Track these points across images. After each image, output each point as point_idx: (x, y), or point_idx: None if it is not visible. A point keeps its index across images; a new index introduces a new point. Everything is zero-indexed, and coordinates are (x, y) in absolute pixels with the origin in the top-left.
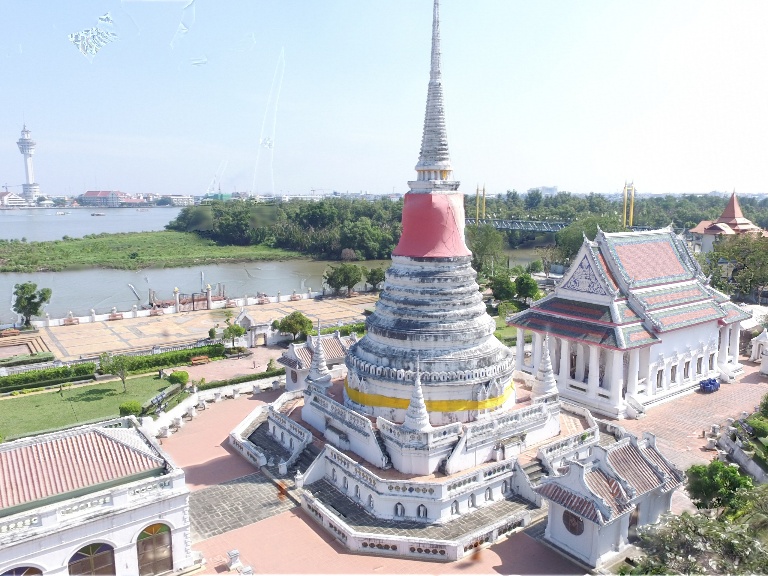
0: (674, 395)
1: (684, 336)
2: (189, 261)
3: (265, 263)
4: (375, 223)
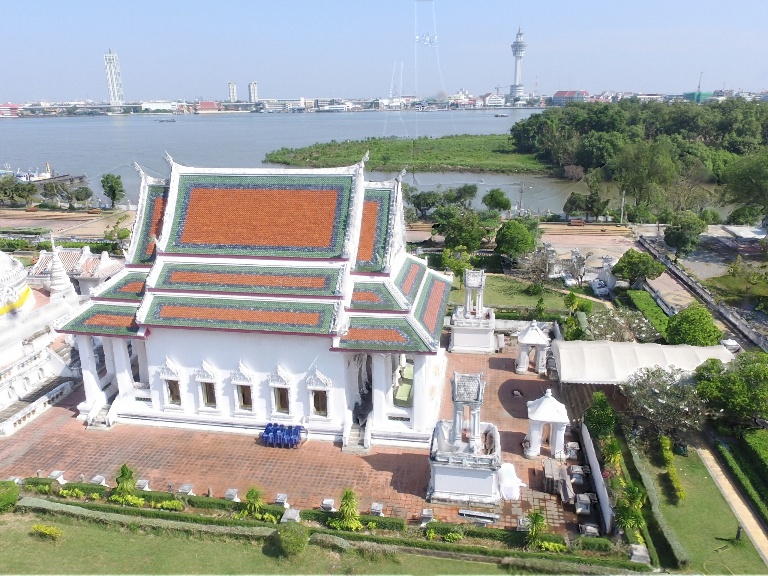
0: (209, 425)
1: (232, 344)
2: (424, 167)
3: (492, 175)
4: (684, 134)
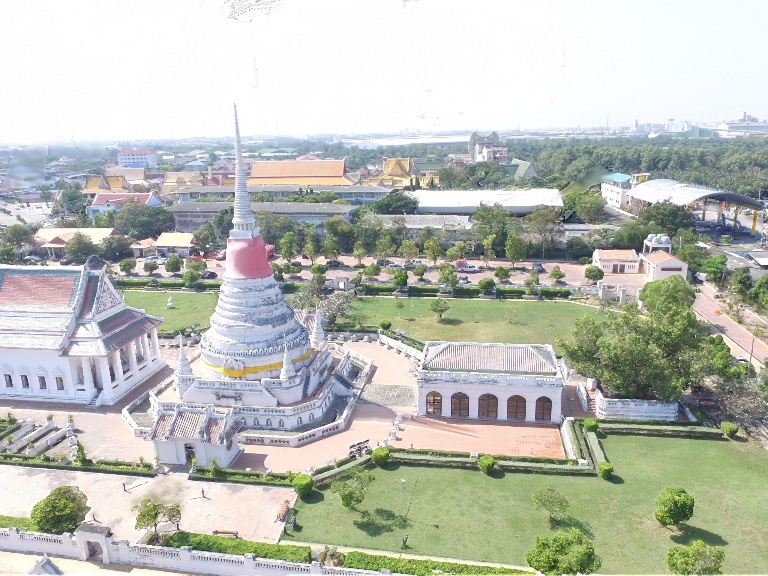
0: None
1: None
2: None
3: None
4: None
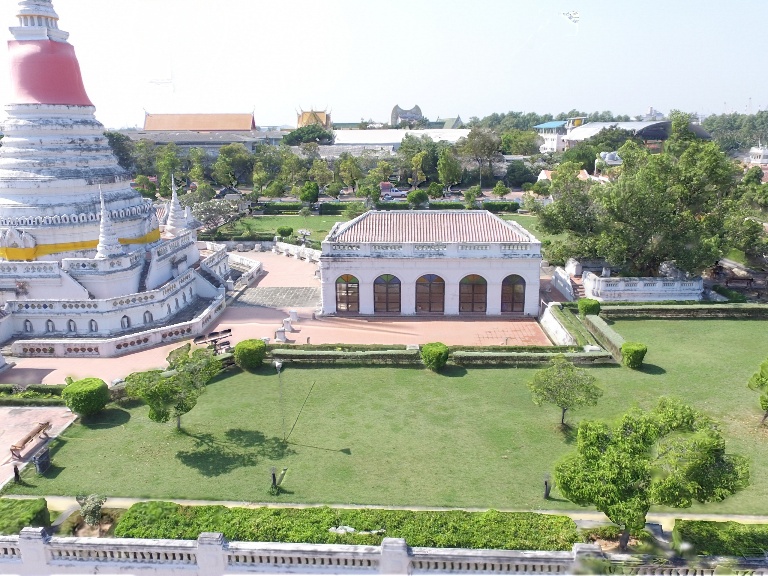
0: None
1: None
2: None
3: None
4: None
